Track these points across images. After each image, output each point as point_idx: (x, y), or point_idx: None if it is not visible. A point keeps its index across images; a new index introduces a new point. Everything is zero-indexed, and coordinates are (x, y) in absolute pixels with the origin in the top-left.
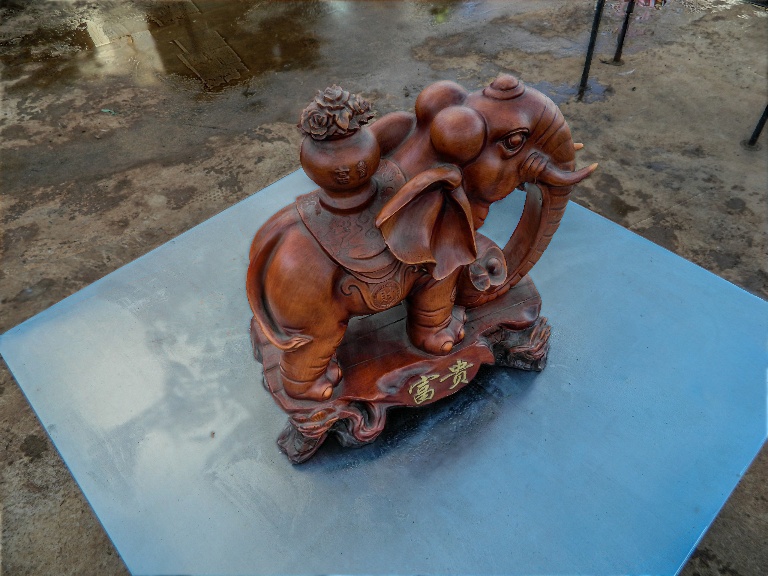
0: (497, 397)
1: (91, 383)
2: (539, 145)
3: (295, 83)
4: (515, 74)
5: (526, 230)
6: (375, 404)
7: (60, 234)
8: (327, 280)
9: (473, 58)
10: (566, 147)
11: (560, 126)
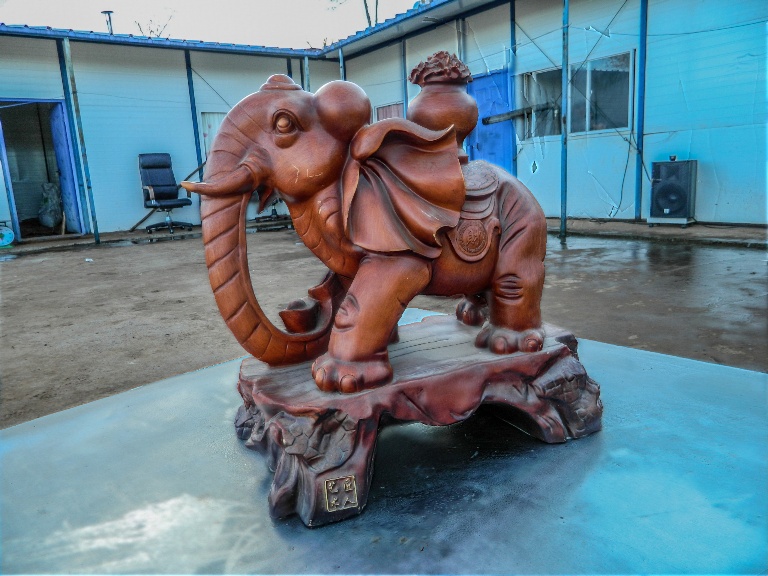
0: None
1: (763, 389)
2: None
3: None
4: None
5: None
6: None
7: None
8: None
9: None
10: None
11: None
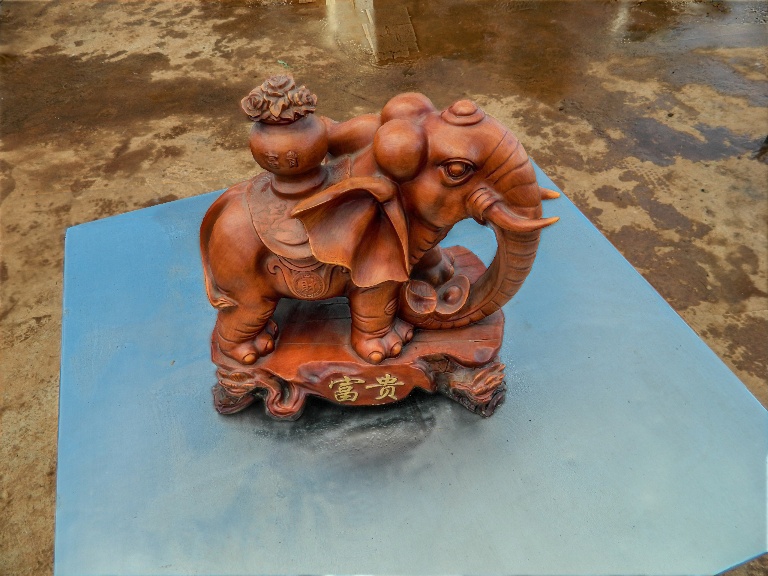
0: (428, 425)
1: (111, 286)
2: (490, 181)
3: (456, 73)
4: (692, 112)
5: (495, 268)
6: (296, 386)
7: (199, 160)
8: (251, 254)
9: (652, 85)
10: (523, 191)
11: (516, 167)
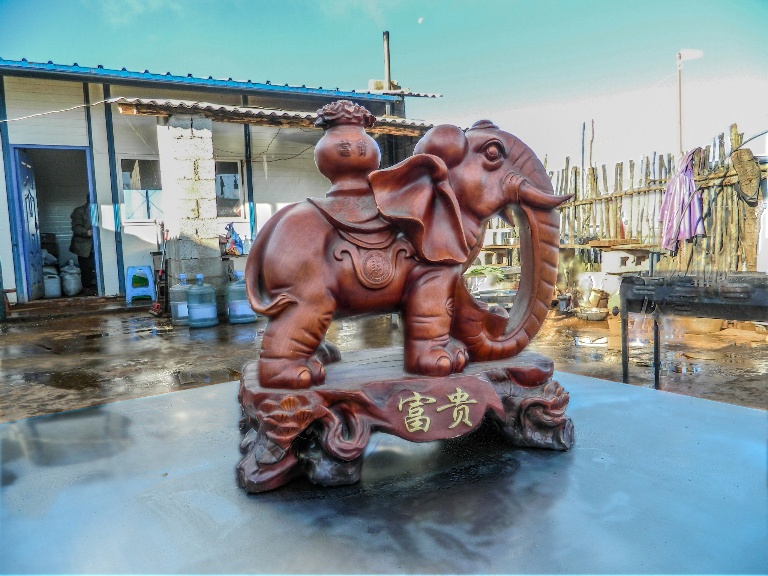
0: (511, 463)
1: (57, 445)
2: (517, 168)
3: None
4: None
5: (525, 283)
6: (358, 415)
7: None
8: (321, 235)
9: None
10: (542, 175)
11: (533, 155)
